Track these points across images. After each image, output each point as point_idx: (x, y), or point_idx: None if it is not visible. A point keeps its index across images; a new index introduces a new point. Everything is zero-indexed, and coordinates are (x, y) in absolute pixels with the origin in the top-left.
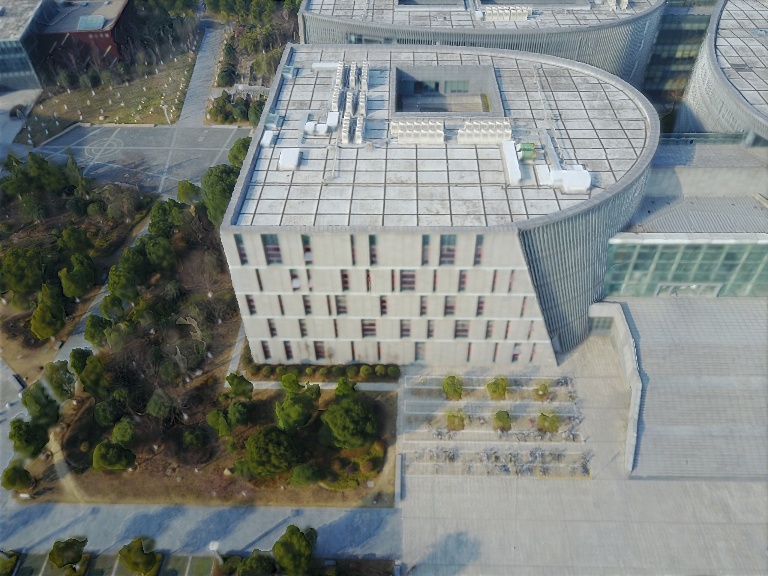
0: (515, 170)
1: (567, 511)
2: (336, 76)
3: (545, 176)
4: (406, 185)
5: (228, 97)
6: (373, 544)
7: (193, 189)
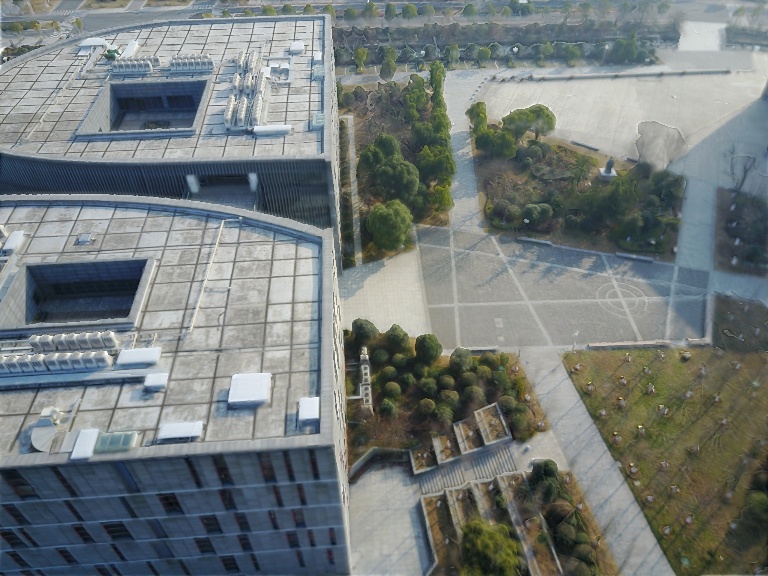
0: (132, 43)
1: None
2: (263, 116)
3: (111, 48)
4: (213, 43)
5: (512, 423)
6: None
7: (436, 196)
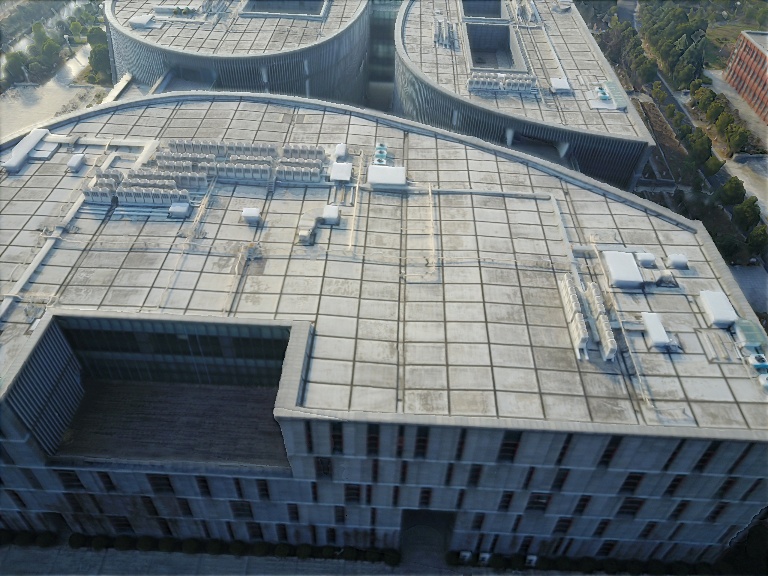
0: (161, 6)
1: (28, 125)
2: None
3: None
4: None
5: None
6: (54, 81)
7: None
